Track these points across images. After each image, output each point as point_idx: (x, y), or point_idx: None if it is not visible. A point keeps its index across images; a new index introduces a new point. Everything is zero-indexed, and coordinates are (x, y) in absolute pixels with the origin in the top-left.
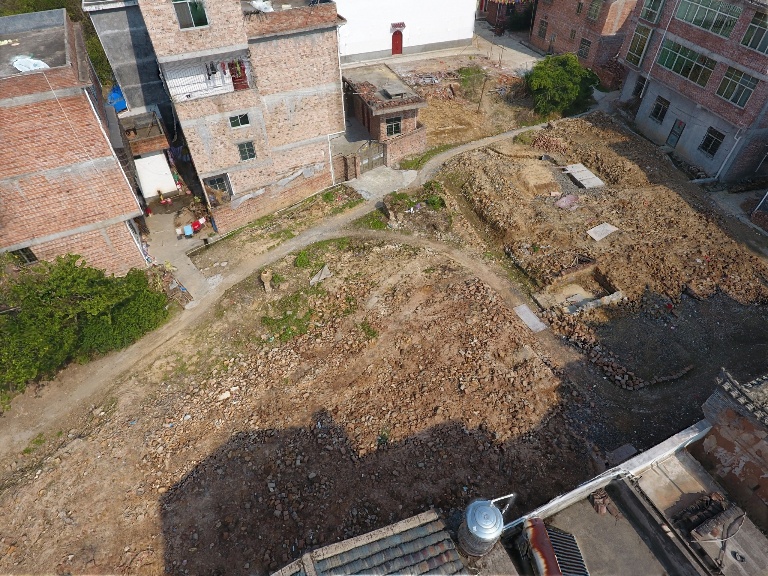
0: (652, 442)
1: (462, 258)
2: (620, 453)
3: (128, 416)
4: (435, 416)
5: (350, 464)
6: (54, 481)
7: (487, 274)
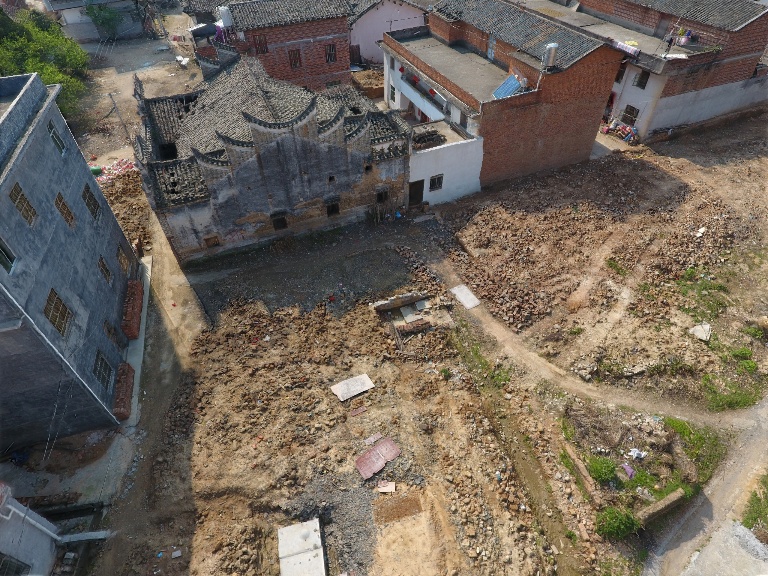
0: (402, 222)
1: (538, 365)
2: (424, 219)
3: (761, 221)
4: None
5: None
6: (763, 191)
7: (507, 340)
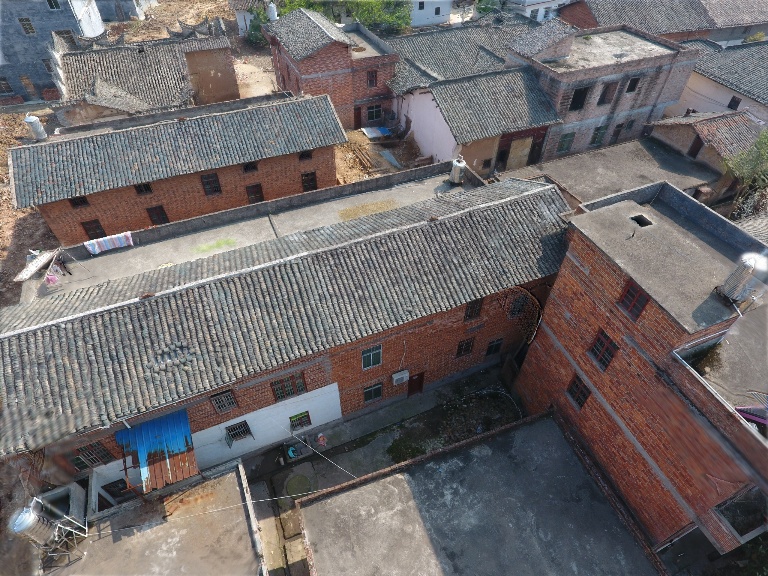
0: None
1: None
2: None
3: None
4: (2, 227)
5: (1, 262)
6: None
7: None
